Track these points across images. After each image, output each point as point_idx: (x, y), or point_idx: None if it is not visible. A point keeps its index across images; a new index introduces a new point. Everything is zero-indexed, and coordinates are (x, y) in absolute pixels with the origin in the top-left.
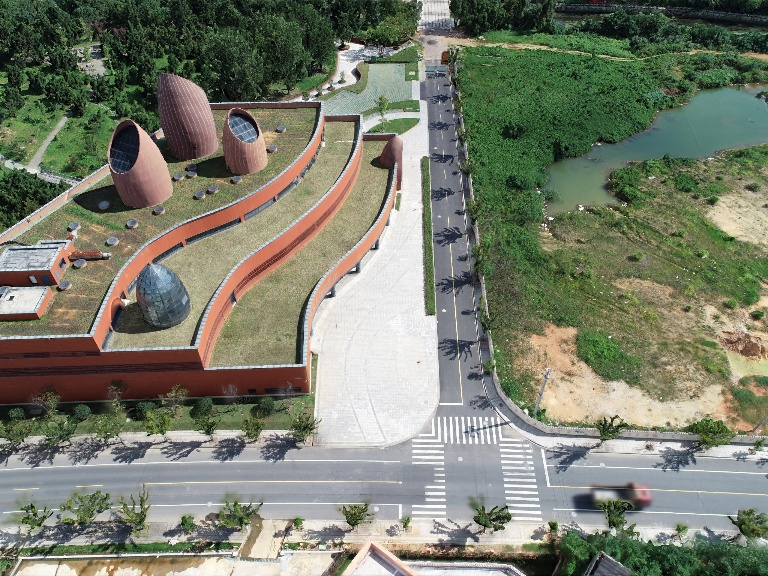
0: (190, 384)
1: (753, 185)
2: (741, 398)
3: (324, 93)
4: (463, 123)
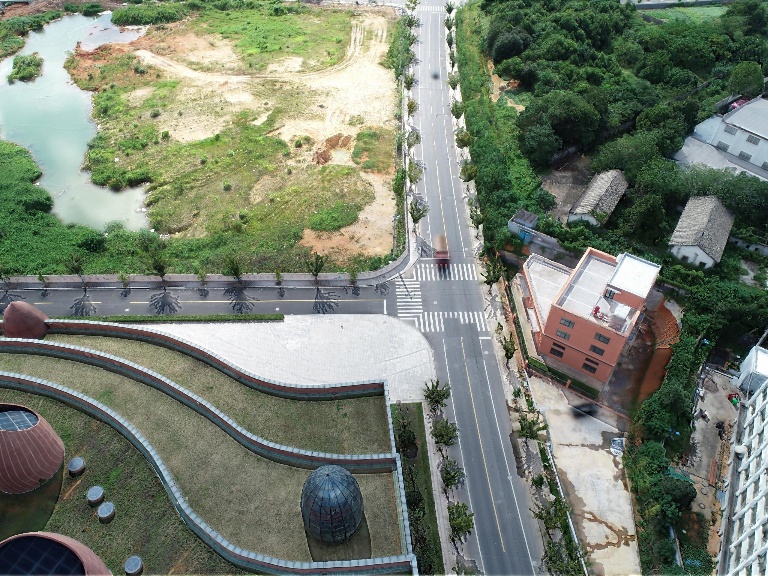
0: None
1: (155, 112)
2: (372, 165)
3: None
4: None
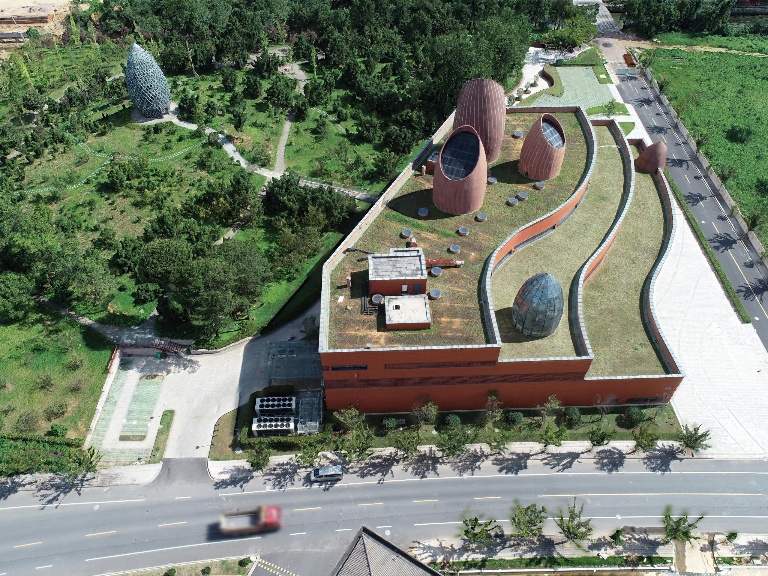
0: (559, 394)
1: None
2: None
3: (522, 96)
4: (682, 127)
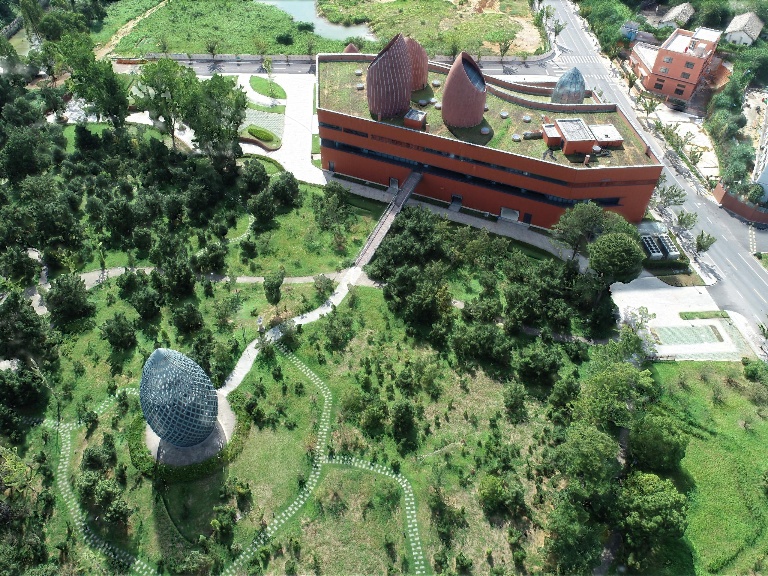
0: None
1: None
2: (516, 13)
3: (177, 126)
4: None
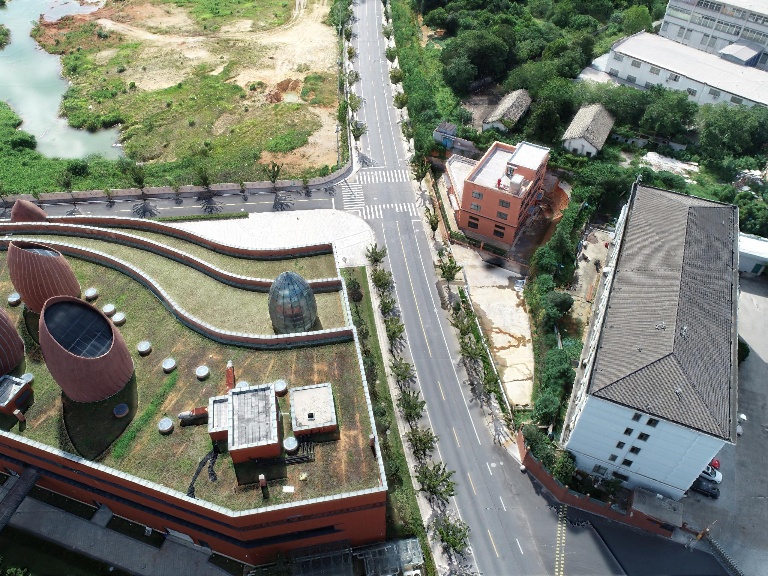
0: None
1: (121, 67)
2: (318, 101)
3: None
4: None
